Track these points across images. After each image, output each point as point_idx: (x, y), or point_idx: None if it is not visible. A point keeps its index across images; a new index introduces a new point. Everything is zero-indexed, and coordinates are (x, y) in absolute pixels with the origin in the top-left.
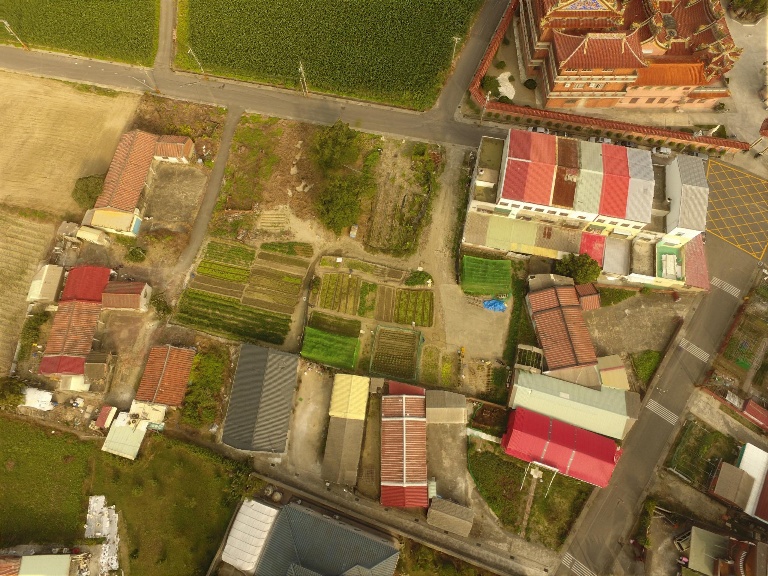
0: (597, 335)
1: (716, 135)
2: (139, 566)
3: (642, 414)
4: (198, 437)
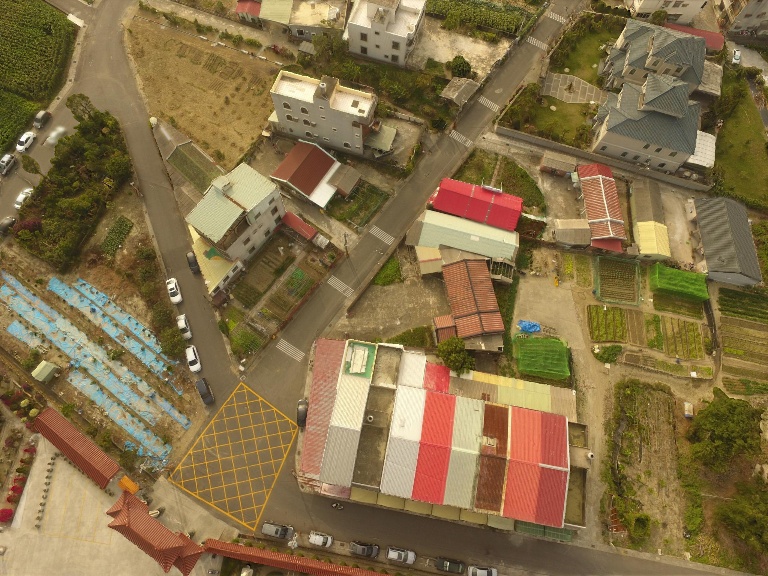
0: (431, 299)
1: (234, 575)
2: (760, 142)
3: (400, 233)
4: (759, 215)
